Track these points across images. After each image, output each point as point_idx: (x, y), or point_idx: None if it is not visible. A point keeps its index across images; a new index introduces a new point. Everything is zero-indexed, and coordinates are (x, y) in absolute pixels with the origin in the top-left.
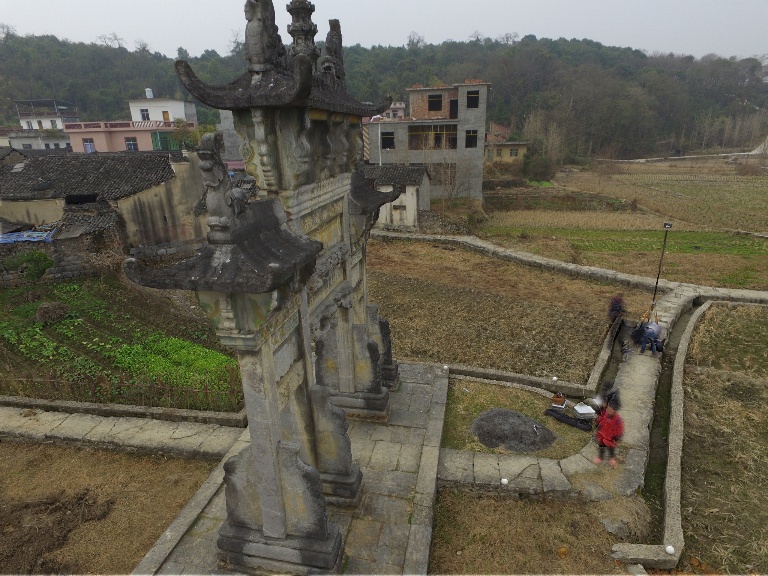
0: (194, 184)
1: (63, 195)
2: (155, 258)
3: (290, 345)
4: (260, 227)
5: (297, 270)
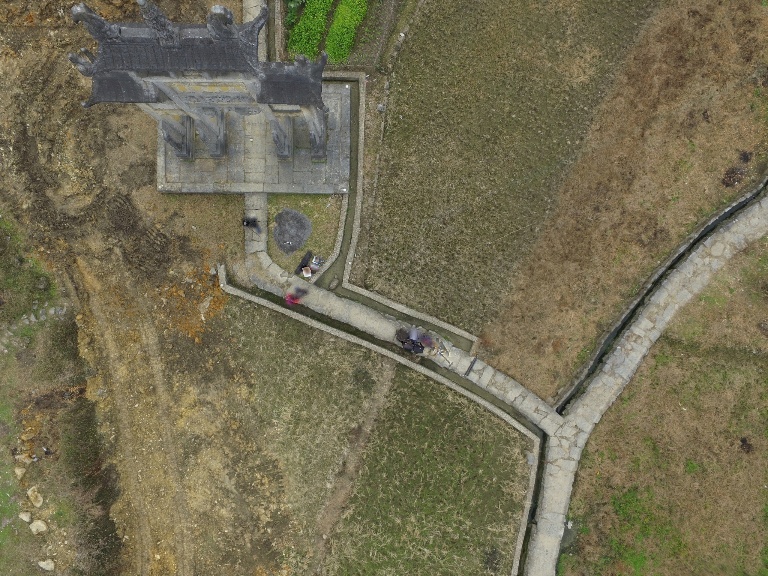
0: None
1: None
2: None
3: None
4: (116, 79)
5: None
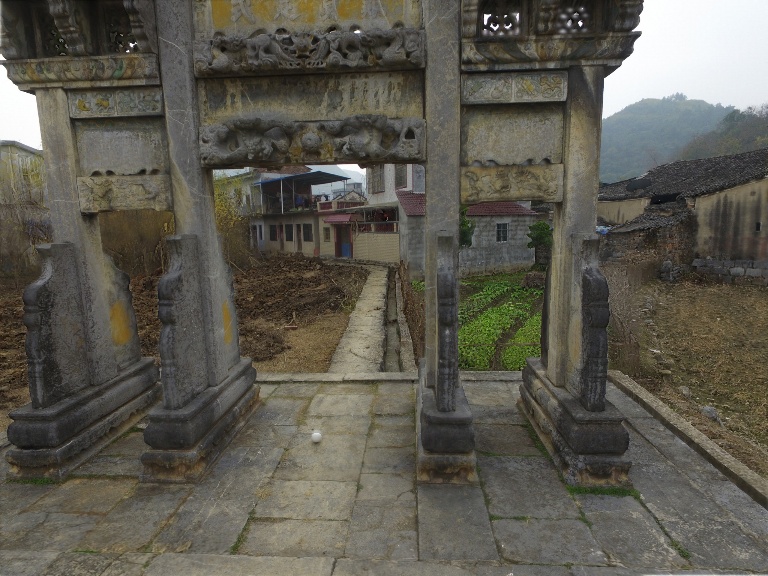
0: None
1: (649, 194)
2: (724, 277)
3: (145, 140)
4: None
5: None
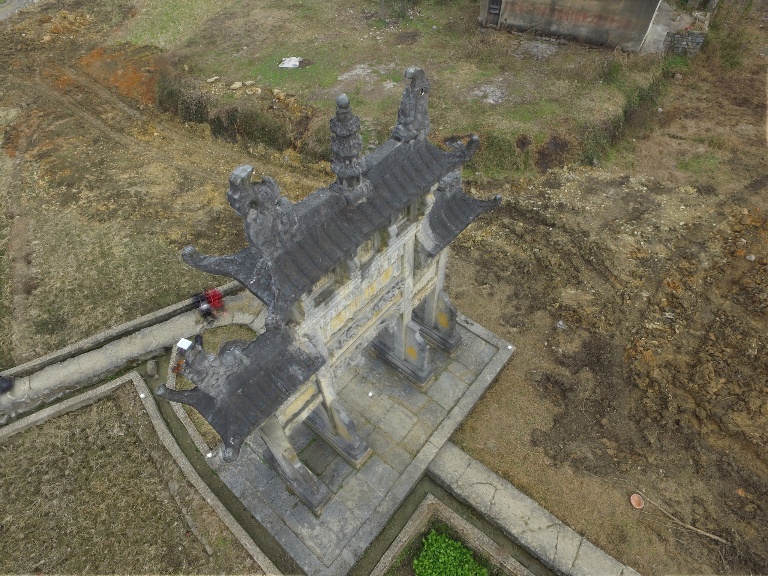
0: None
1: None
2: None
3: None
4: None
5: None
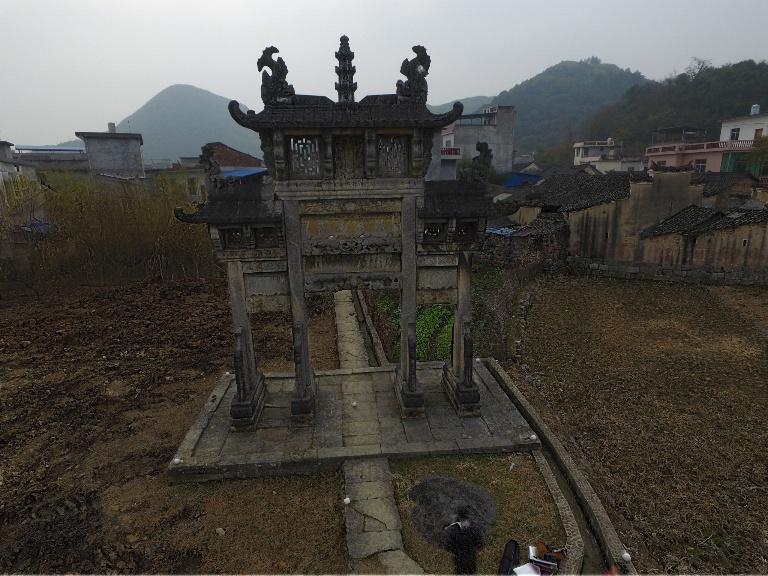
0: (654, 206)
1: (540, 204)
2: (586, 270)
3: (277, 281)
4: (238, 197)
5: (248, 226)
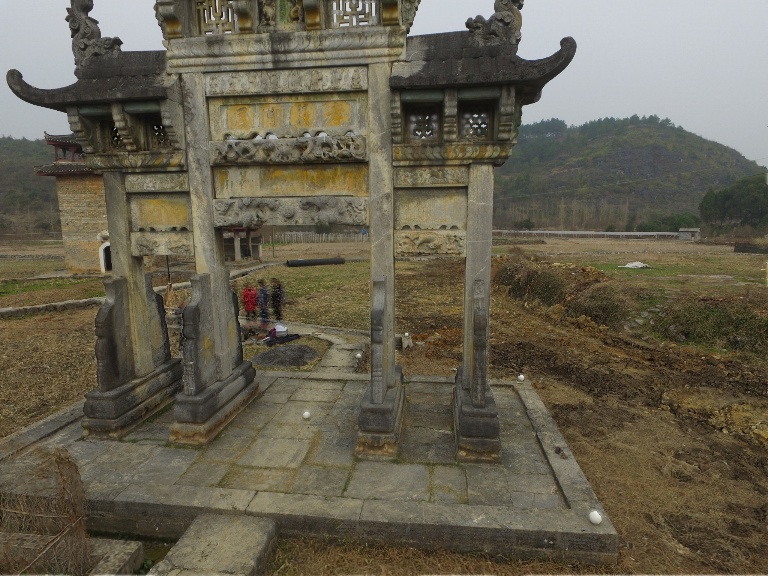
0: None
1: None
2: None
3: None
4: None
5: None
